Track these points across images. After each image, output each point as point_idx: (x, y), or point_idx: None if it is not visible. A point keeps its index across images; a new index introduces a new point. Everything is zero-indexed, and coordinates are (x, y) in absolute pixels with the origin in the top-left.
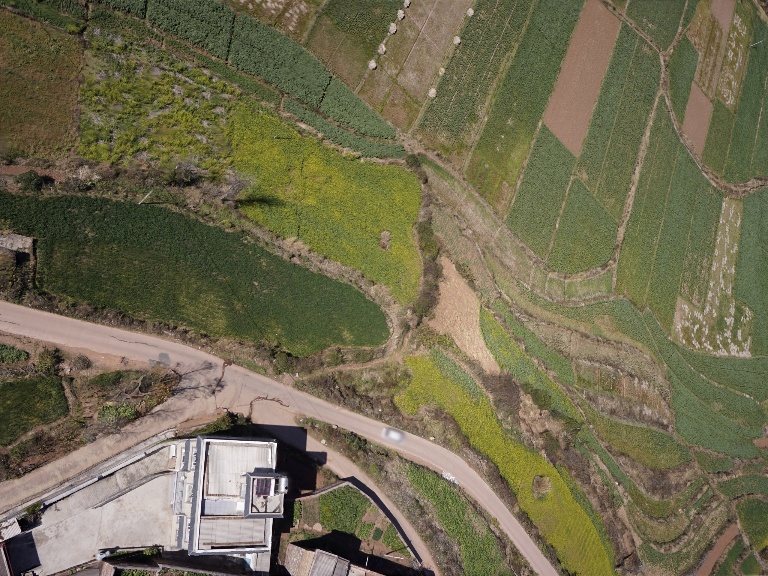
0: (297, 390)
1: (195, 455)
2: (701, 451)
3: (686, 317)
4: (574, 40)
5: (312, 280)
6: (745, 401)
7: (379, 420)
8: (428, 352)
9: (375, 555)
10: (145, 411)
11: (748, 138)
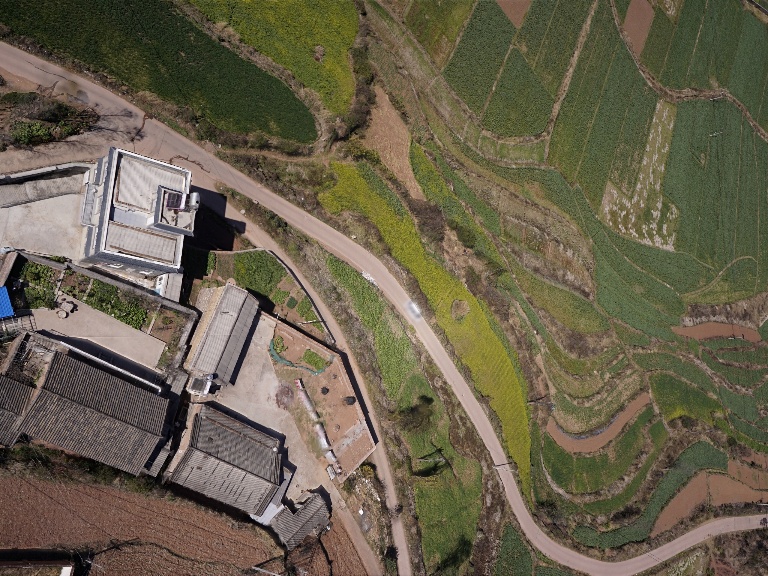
0: (219, 159)
1: None
2: (620, 324)
3: (614, 201)
4: None
5: (241, 65)
6: (665, 290)
7: (301, 208)
8: (355, 164)
9: (288, 321)
10: (59, 137)
11: (686, 50)
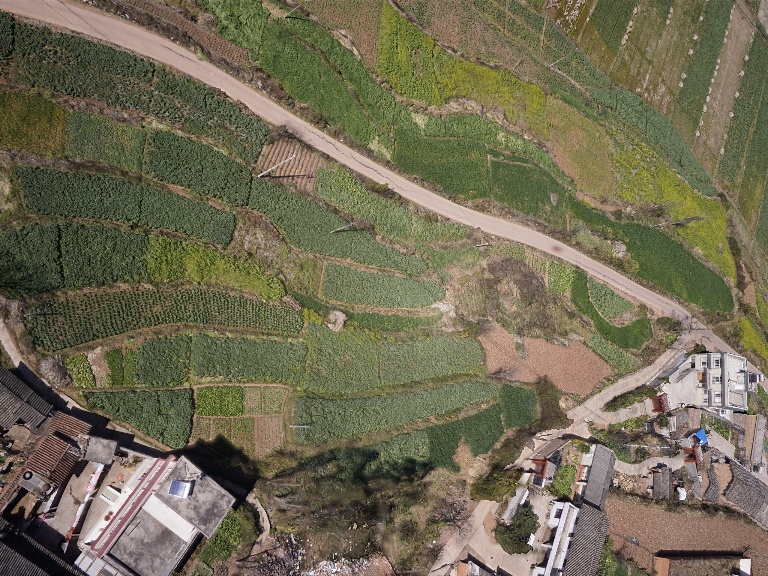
0: (714, 334)
1: (717, 361)
2: None
3: None
4: None
5: (708, 272)
6: None
7: (740, 354)
8: (746, 317)
9: None
10: None
11: None
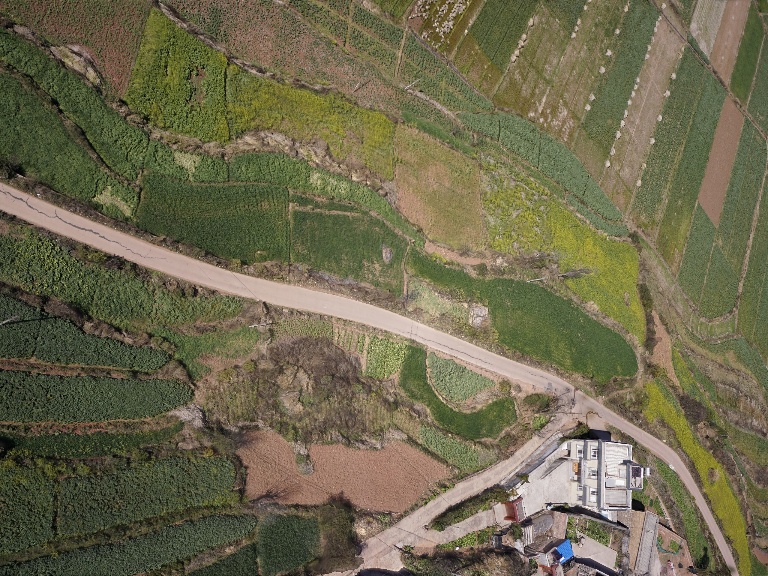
0: (605, 407)
1: (594, 450)
2: None
3: None
4: (717, 134)
5: (603, 332)
6: None
7: (640, 428)
8: (654, 380)
9: None
10: (549, 420)
11: None
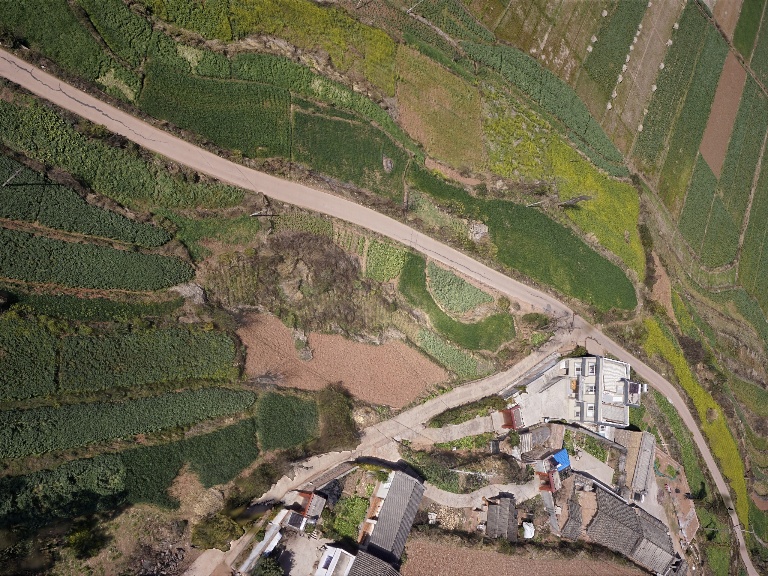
0: (604, 335)
1: (592, 367)
2: None
3: None
4: (719, 87)
5: (603, 263)
6: None
7: (639, 359)
8: (653, 317)
9: None
10: (547, 339)
11: None
